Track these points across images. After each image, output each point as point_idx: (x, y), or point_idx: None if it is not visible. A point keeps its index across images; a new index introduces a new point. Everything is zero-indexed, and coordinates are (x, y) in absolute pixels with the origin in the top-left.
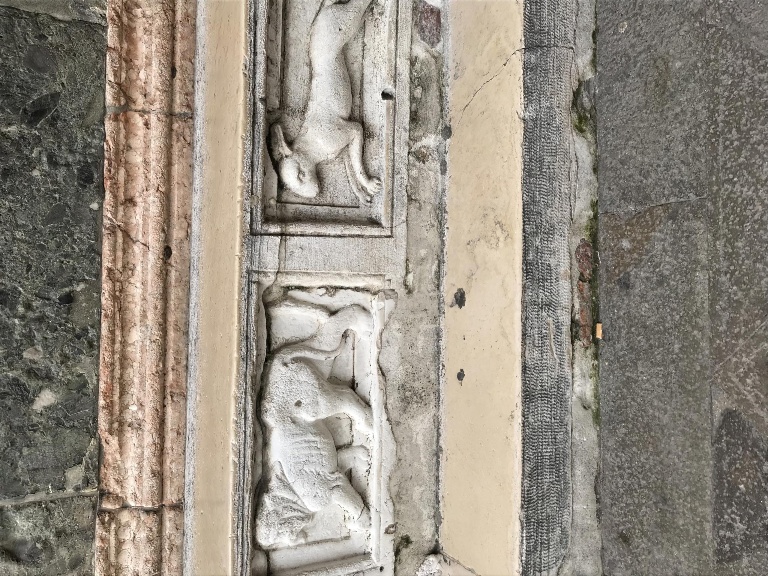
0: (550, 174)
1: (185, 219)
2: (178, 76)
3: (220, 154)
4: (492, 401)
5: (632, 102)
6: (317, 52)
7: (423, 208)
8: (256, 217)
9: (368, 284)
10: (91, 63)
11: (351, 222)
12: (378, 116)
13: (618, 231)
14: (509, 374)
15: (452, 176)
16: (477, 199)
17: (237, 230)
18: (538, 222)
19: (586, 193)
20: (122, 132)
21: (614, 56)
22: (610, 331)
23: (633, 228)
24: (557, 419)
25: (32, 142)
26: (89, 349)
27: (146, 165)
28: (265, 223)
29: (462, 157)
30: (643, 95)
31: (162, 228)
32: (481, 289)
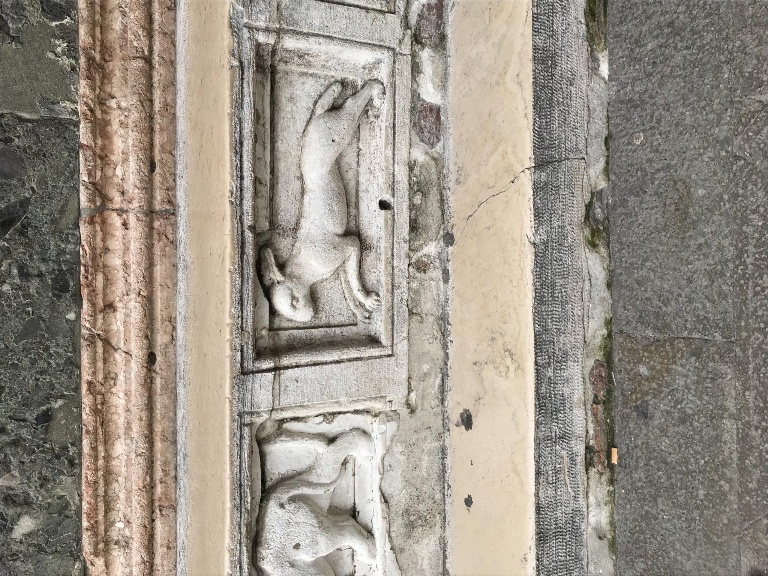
0: (562, 298)
1: (170, 322)
2: (158, 170)
3: (206, 274)
4: (503, 538)
5: (649, 221)
6: (309, 166)
7: (425, 321)
8: (247, 354)
9: (368, 407)
10: (63, 162)
11: (349, 343)
12: (375, 226)
13: (635, 355)
14: (522, 514)
15: (455, 287)
16: (484, 319)
17: (227, 371)
18: (550, 351)
19: (600, 311)
20: (99, 234)
21: (629, 167)
22: (626, 458)
23: (651, 356)
24: (572, 556)
25: (1, 254)
26: (70, 469)
27: (126, 268)
28: (257, 360)
29: (466, 270)
30: (662, 216)
31: (145, 334)
32: (489, 416)
